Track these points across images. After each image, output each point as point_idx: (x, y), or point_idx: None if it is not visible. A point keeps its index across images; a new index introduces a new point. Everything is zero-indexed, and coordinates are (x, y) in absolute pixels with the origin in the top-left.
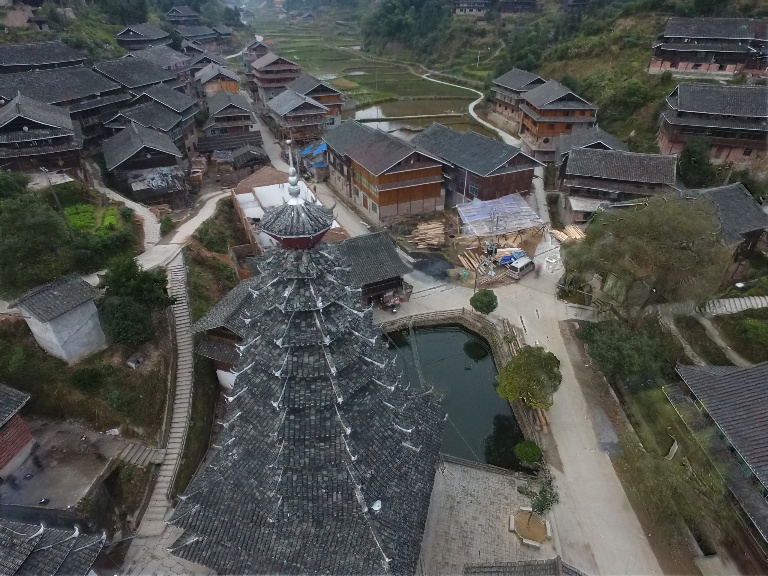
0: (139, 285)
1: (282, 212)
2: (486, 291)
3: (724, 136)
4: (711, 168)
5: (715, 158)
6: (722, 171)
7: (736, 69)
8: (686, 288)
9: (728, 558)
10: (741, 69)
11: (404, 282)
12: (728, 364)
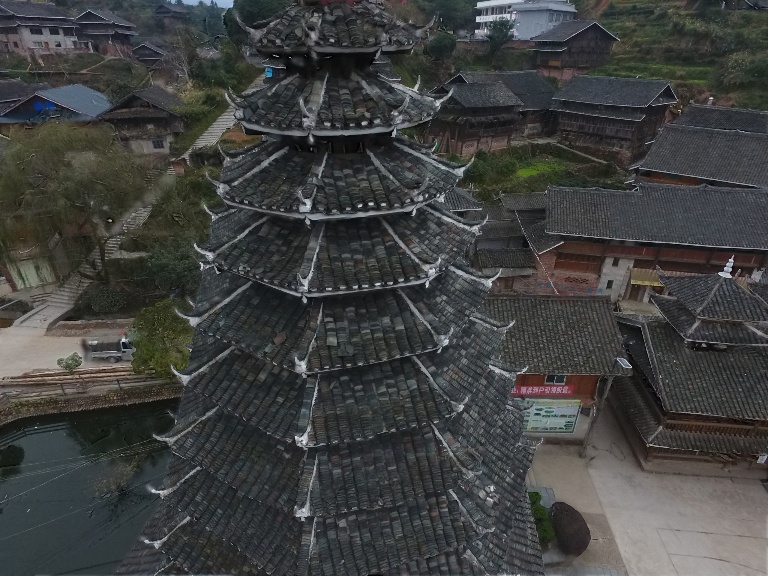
0: None
1: None
2: None
3: None
4: None
5: None
6: None
7: None
8: (161, 179)
9: None
10: None
11: None
12: None
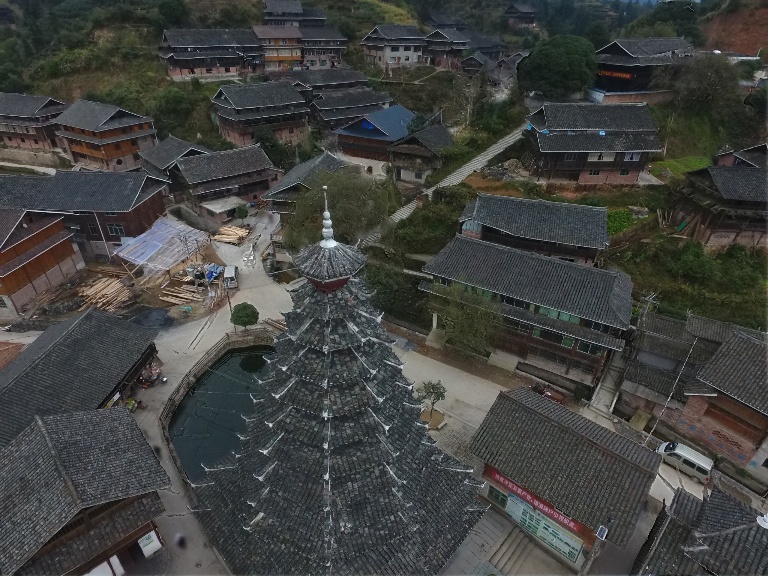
0: None
1: (331, 256)
2: (244, 305)
3: (273, 122)
4: (283, 148)
5: (281, 140)
6: (289, 148)
7: (237, 70)
8: (386, 223)
9: (496, 350)
10: (239, 70)
11: None
12: (411, 261)
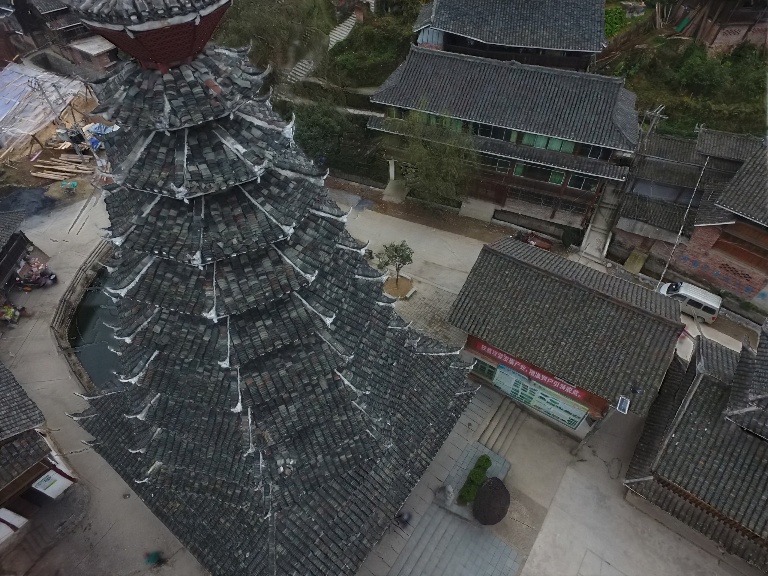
0: None
1: None
2: None
3: None
4: None
5: None
6: None
7: None
8: (315, 39)
9: (468, 198)
10: None
11: (26, 235)
12: (356, 97)
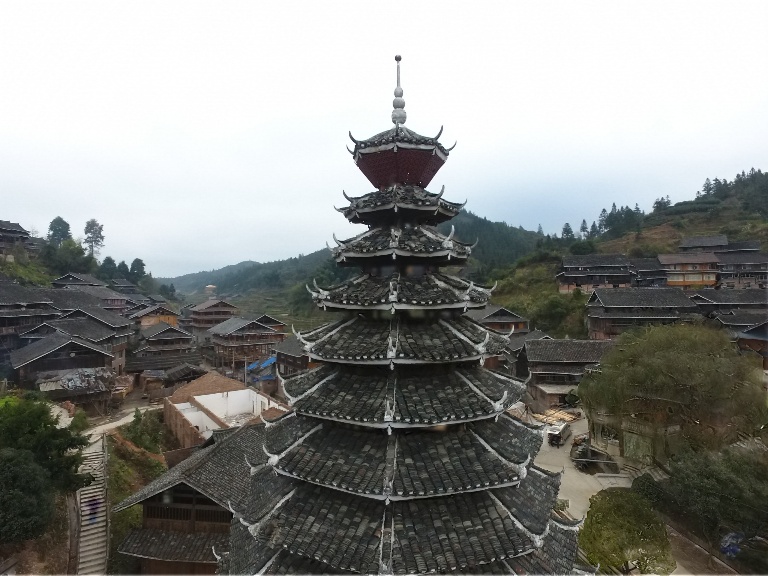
0: (48, 440)
1: None
2: None
3: None
4: None
5: None
6: None
7: None
8: (746, 392)
9: None
10: None
11: None
12: None
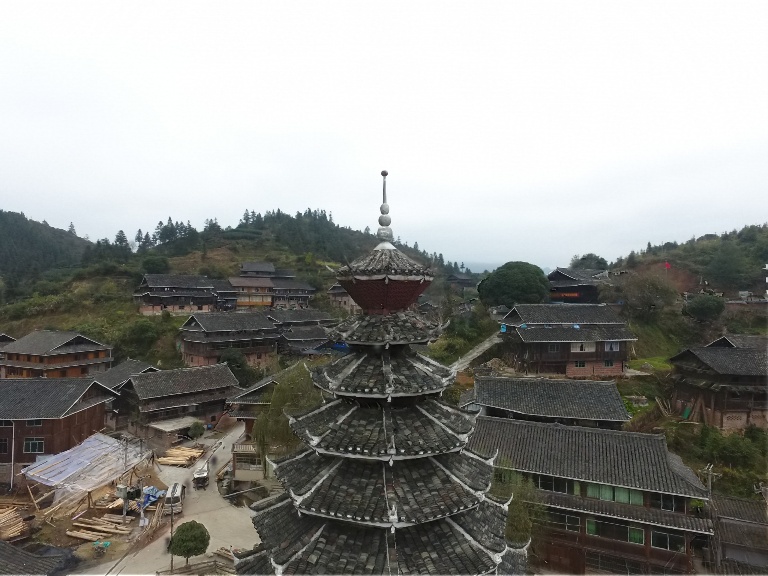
0: None
1: (392, 256)
2: (191, 522)
3: (242, 347)
4: (250, 369)
5: (249, 361)
6: (256, 370)
7: (209, 308)
8: None
9: (539, 569)
10: (212, 308)
11: None
12: None
